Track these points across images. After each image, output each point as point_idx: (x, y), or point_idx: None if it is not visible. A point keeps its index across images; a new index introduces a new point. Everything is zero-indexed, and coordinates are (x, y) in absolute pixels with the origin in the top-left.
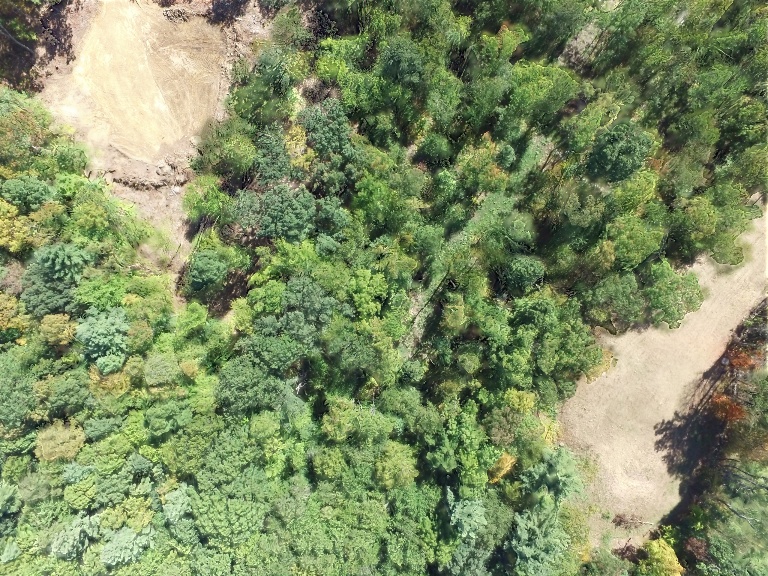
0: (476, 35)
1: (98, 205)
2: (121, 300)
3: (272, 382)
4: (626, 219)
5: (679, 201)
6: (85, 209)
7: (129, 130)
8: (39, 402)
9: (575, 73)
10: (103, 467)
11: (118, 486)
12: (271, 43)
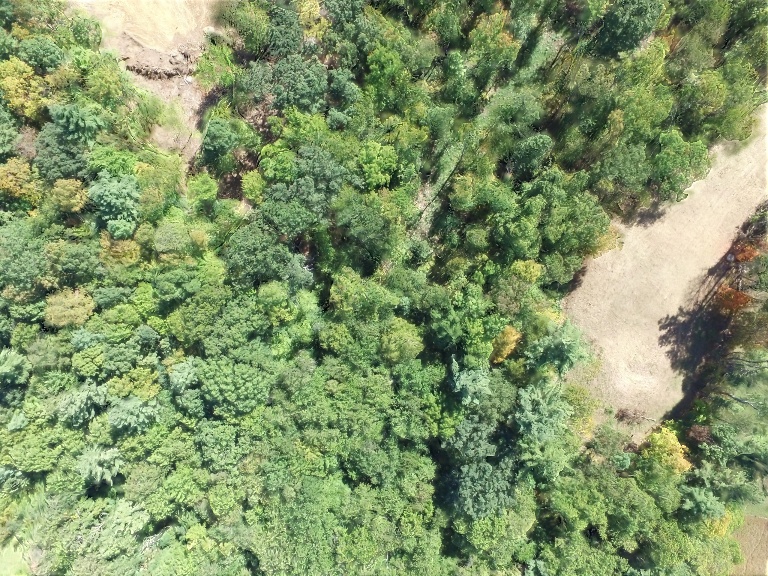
0: None
1: (113, 72)
2: (133, 168)
3: (281, 249)
4: (636, 89)
5: (688, 77)
6: (100, 73)
7: (143, 19)
8: (50, 268)
9: None
10: (111, 334)
11: (126, 354)
12: None
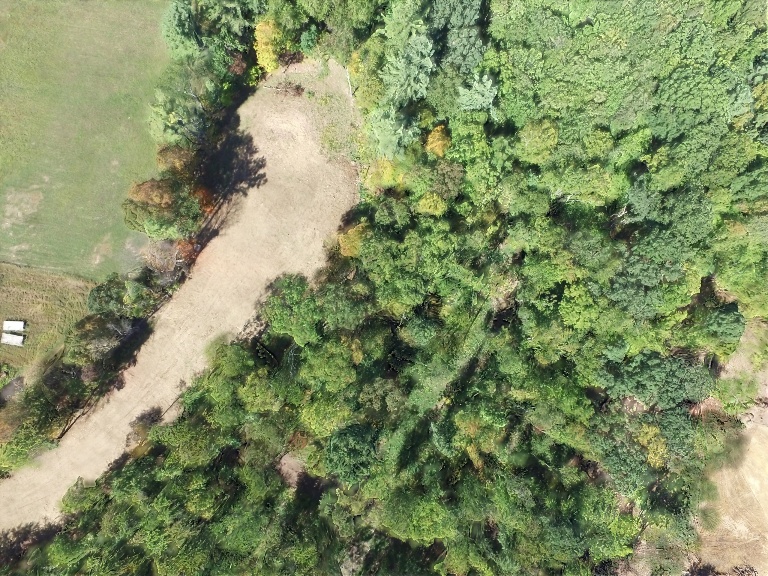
0: (471, 568)
1: None
2: None
3: (666, 218)
4: None
5: None
6: None
7: None
8: None
9: (353, 535)
10: None
11: None
12: (652, 550)
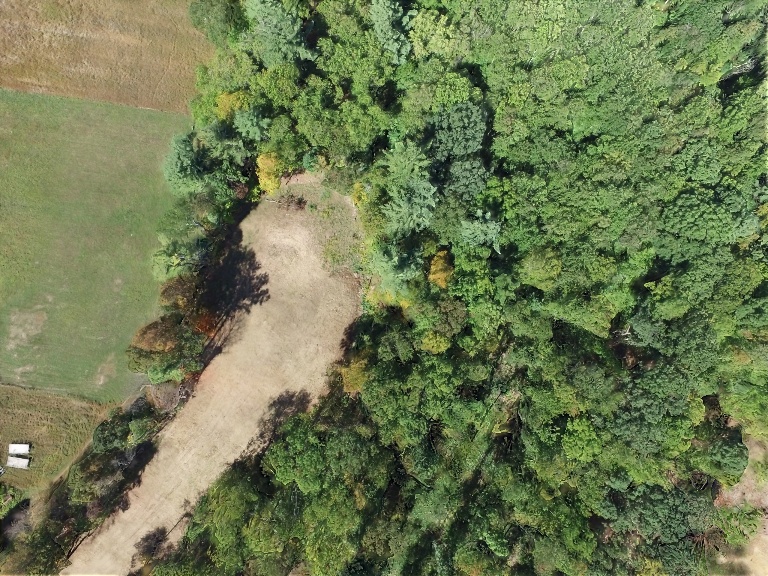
0: None
1: None
2: None
3: (670, 351)
4: None
5: None
6: None
7: None
8: None
9: None
10: None
11: None
12: None
